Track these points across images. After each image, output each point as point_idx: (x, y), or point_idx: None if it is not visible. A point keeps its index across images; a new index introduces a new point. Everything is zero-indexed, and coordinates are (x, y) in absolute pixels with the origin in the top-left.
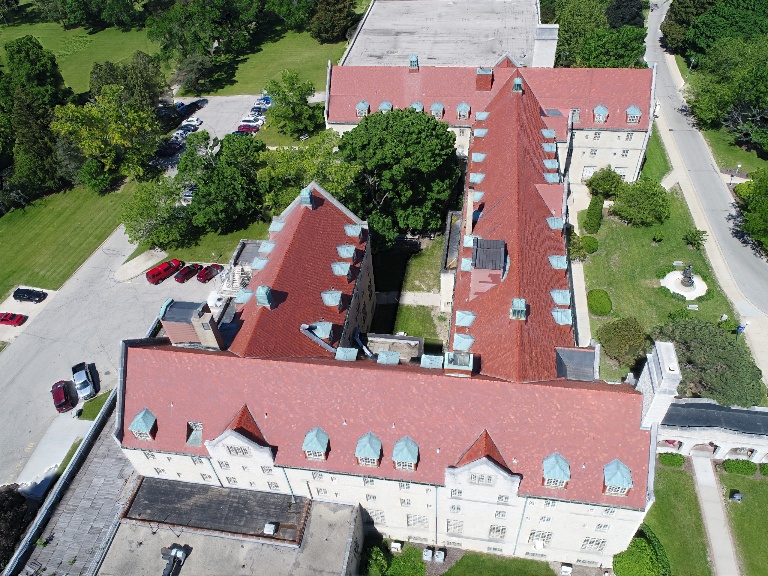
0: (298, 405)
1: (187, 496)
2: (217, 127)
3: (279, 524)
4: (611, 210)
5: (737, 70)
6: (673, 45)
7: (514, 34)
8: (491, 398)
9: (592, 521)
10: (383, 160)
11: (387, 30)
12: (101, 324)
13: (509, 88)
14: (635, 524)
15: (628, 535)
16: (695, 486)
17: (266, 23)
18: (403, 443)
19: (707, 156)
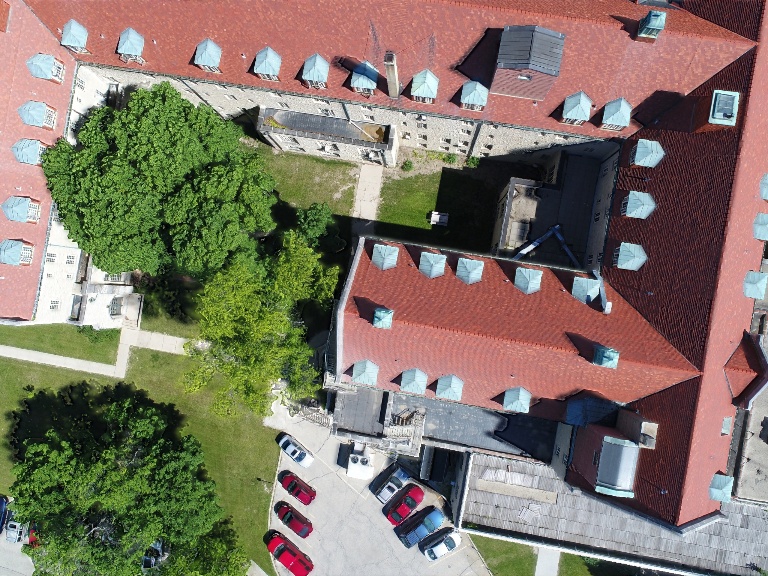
0: None
1: None
2: None
3: None
4: None
5: None
6: None
7: None
8: (760, 79)
9: None
10: None
11: None
12: None
13: None
14: None
15: None
16: None
17: None
18: (766, 188)
19: None
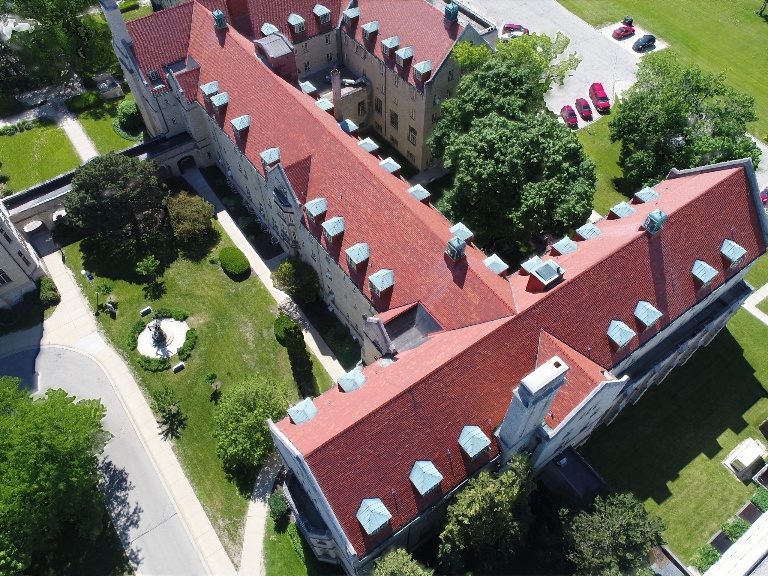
0: None
1: None
2: None
3: None
4: None
5: None
6: None
7: None
8: None
9: None
10: None
11: None
12: None
13: None
14: None
15: None
16: None
17: None
18: None
19: None
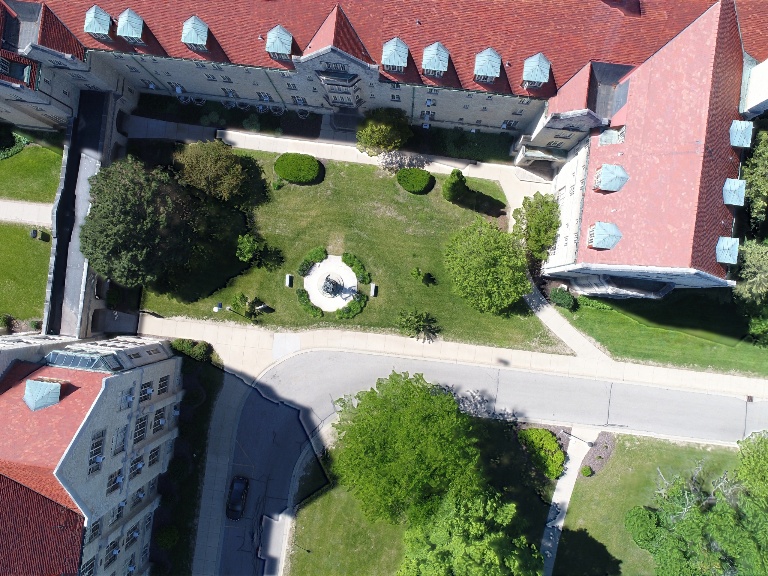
0: None
1: None
2: None
3: None
4: None
5: None
6: None
7: None
8: None
9: None
10: None
11: None
12: None
13: None
14: None
15: None
16: None
17: None
18: None
19: (654, 428)
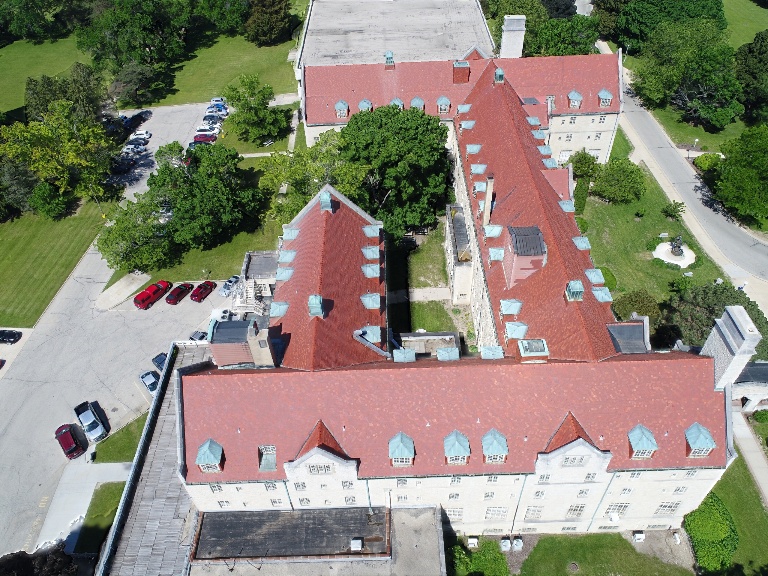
0: (377, 413)
1: (257, 525)
2: (169, 139)
3: (363, 538)
4: (590, 191)
5: (680, 52)
6: (605, 32)
7: (462, 28)
8: (572, 380)
9: (672, 485)
10: (388, 158)
11: (334, 29)
12: (94, 358)
13: (488, 79)
14: (712, 482)
15: (703, 494)
16: (735, 440)
17: (195, 28)
18: (491, 436)
19: (661, 134)
